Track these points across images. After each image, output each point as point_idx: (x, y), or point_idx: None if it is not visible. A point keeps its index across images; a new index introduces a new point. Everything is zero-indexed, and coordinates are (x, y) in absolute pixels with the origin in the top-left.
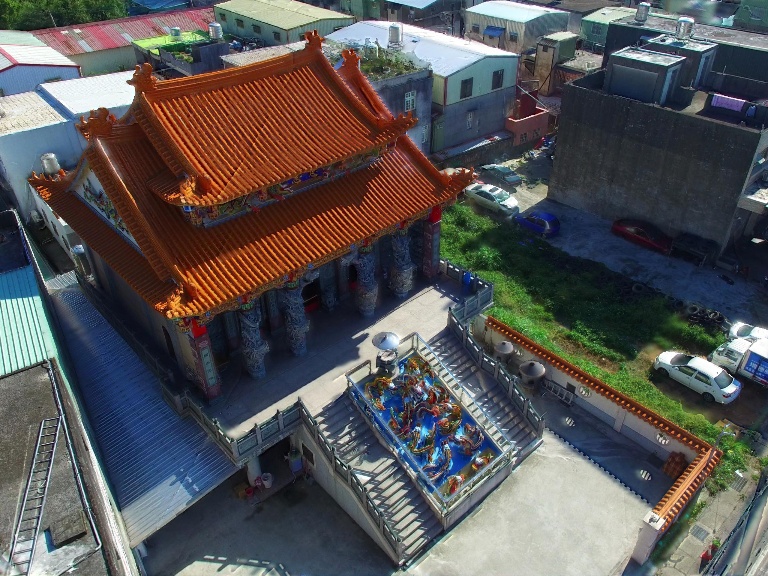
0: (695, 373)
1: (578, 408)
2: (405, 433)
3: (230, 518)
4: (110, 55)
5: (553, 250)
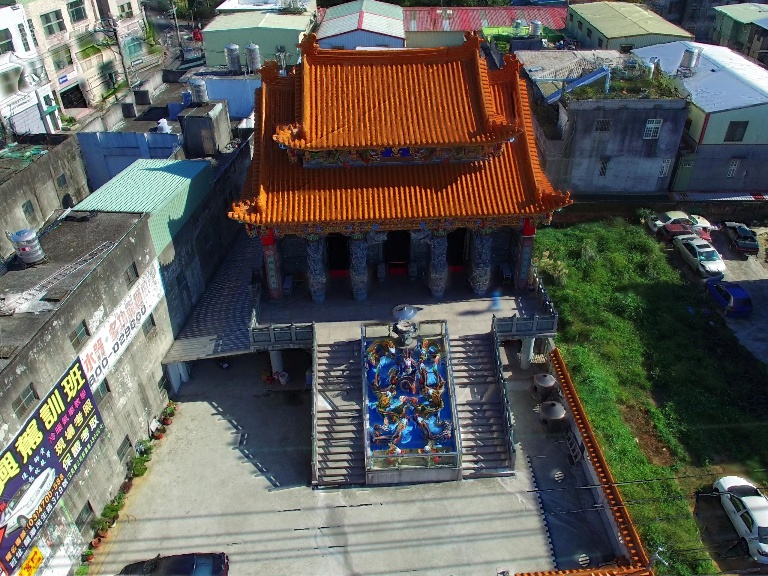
0: (742, 510)
1: (580, 470)
2: None
3: (246, 389)
4: None
5: (719, 329)
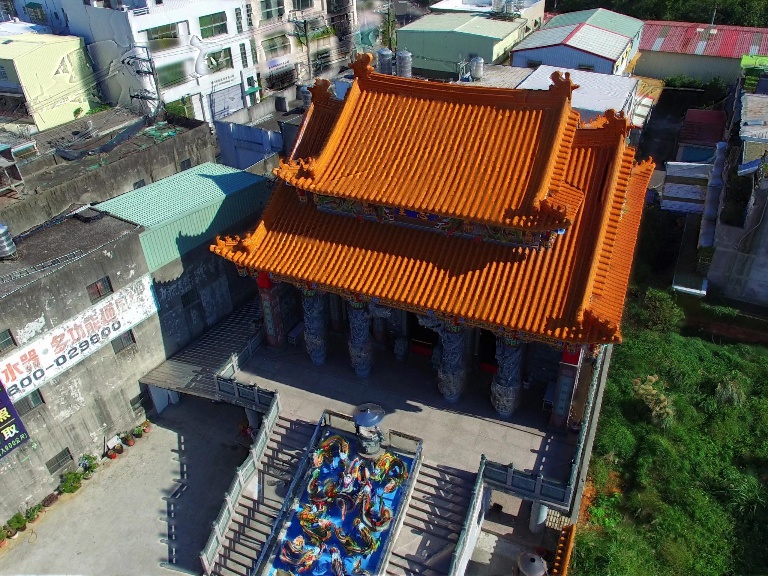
0: None
1: None
2: (313, 502)
3: (220, 433)
4: (718, 63)
5: None
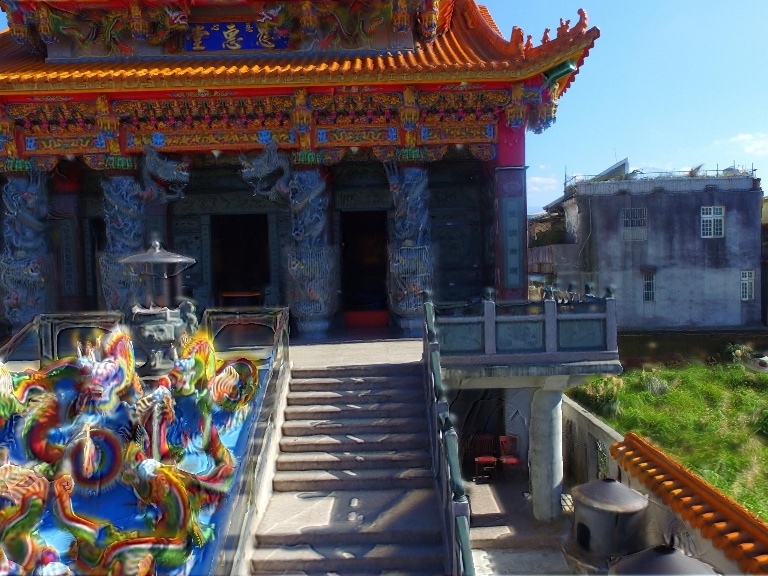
0: None
1: None
2: None
3: None
4: None
5: None
